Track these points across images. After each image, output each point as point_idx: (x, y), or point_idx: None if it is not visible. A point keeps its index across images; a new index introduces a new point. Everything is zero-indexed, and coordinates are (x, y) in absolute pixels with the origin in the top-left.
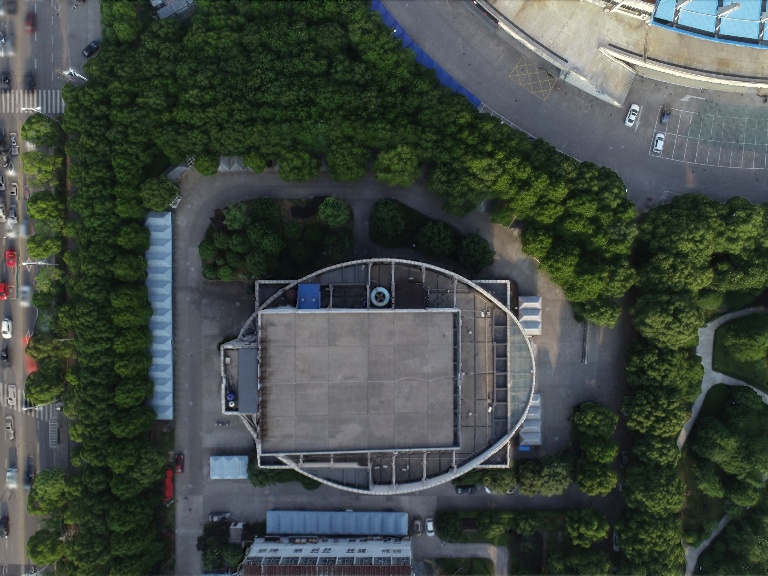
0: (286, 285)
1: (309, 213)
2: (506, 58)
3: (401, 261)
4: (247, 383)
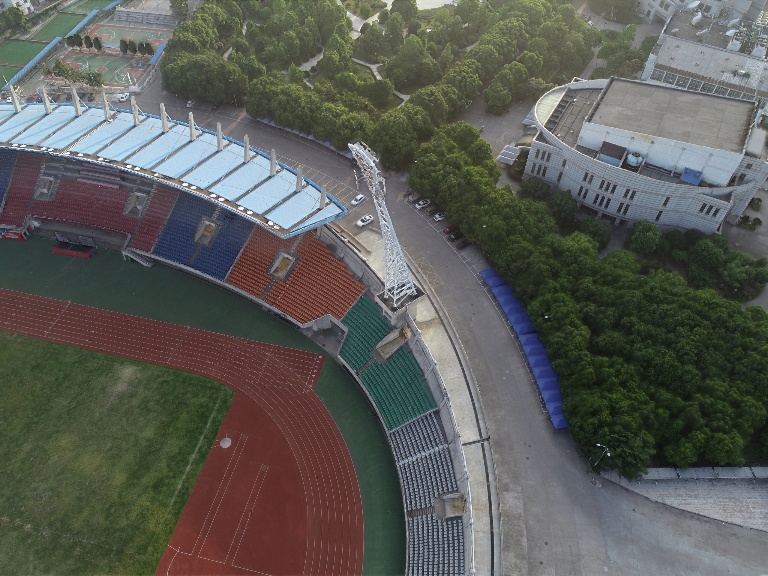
0: (706, 195)
1: (659, 268)
2: (439, 296)
3: (613, 166)
4: (757, 140)
